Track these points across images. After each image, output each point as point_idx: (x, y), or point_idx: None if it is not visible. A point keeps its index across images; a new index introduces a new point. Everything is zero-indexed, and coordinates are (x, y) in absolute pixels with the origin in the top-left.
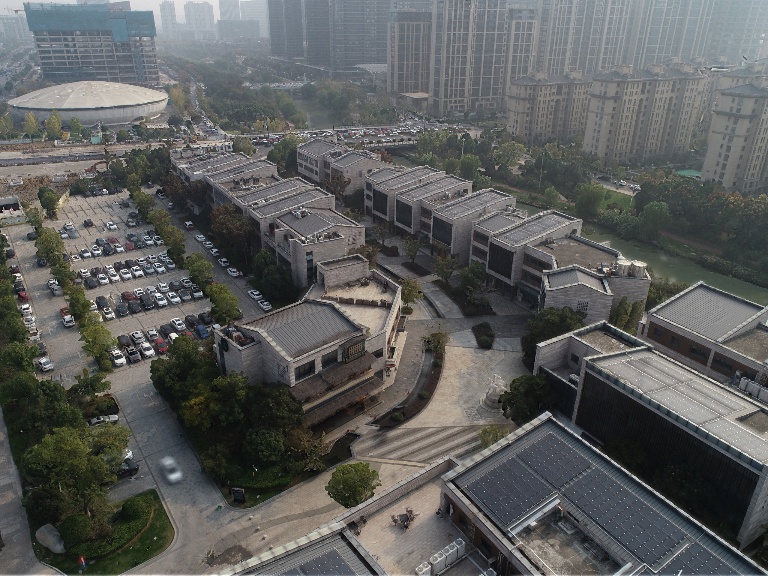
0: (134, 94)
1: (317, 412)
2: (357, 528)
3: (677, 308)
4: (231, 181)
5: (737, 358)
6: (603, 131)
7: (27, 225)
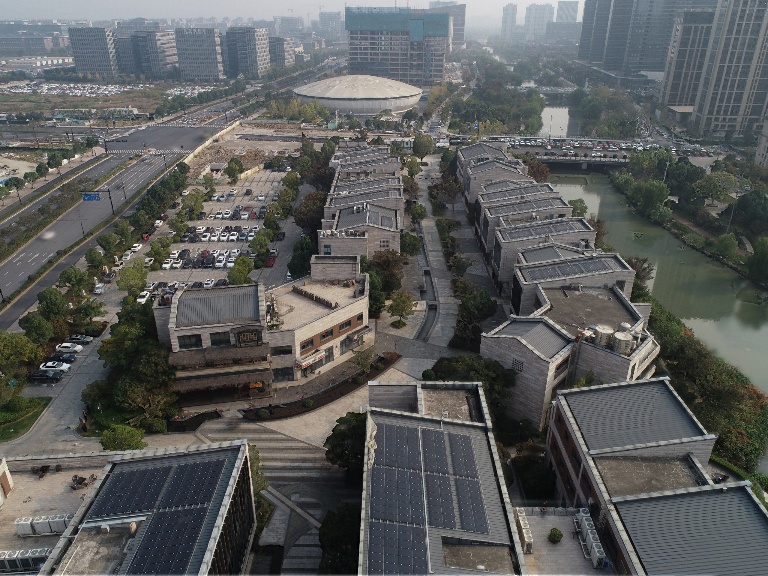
0: (388, 89)
1: (191, 382)
2: (45, 472)
3: (597, 398)
4: (354, 172)
5: (593, 481)
6: None
7: None
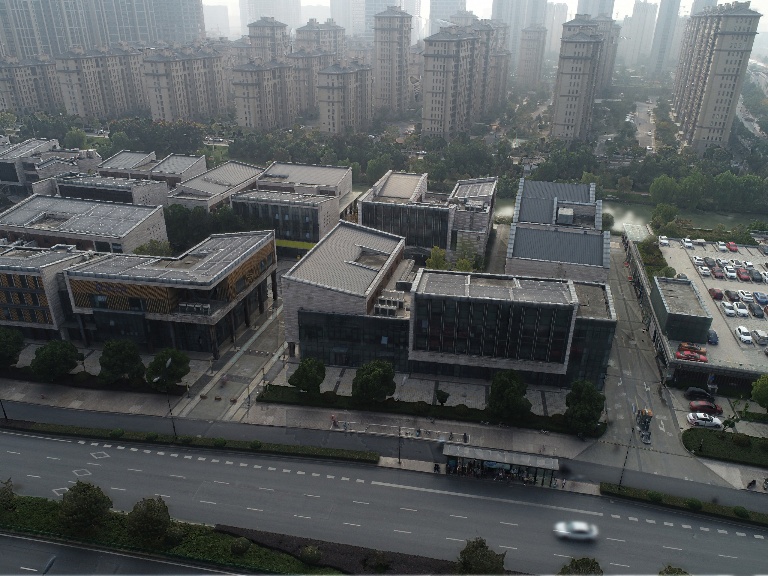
0: None
1: None
2: None
3: (111, 162)
4: None
5: (139, 173)
6: (77, 97)
7: None
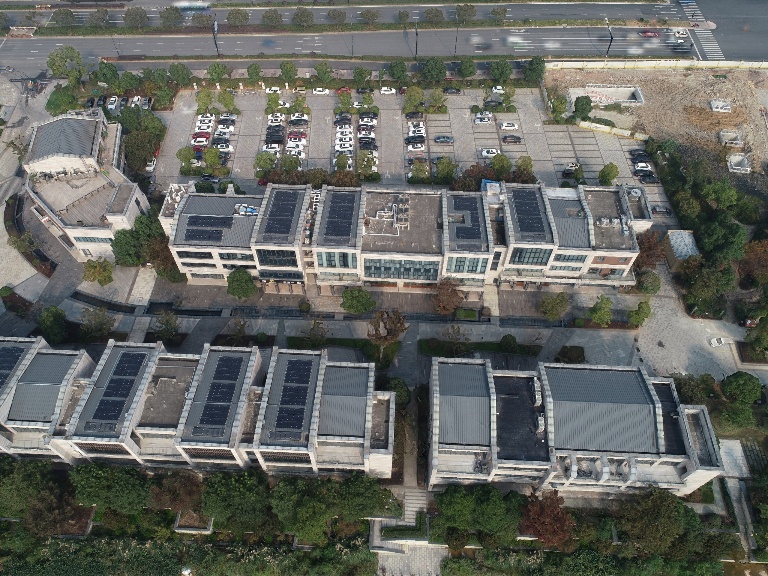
0: None
1: None
2: None
3: None
4: None
5: None
6: None
7: (537, 105)
